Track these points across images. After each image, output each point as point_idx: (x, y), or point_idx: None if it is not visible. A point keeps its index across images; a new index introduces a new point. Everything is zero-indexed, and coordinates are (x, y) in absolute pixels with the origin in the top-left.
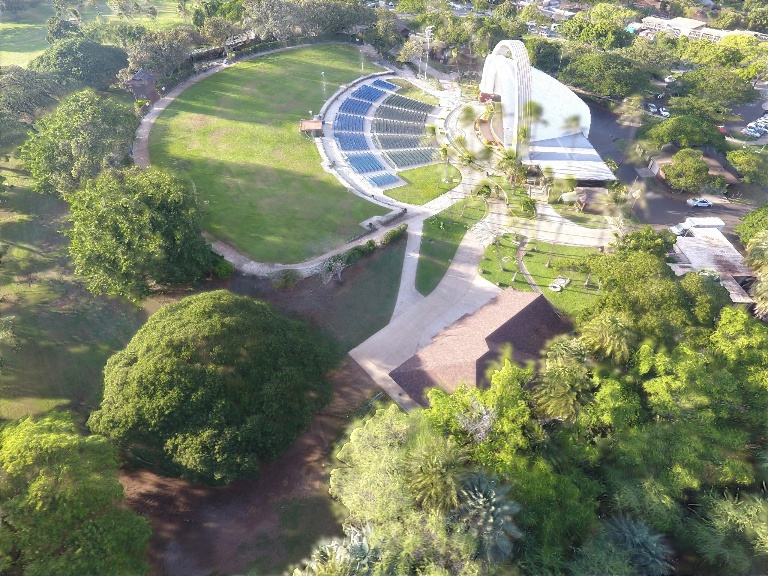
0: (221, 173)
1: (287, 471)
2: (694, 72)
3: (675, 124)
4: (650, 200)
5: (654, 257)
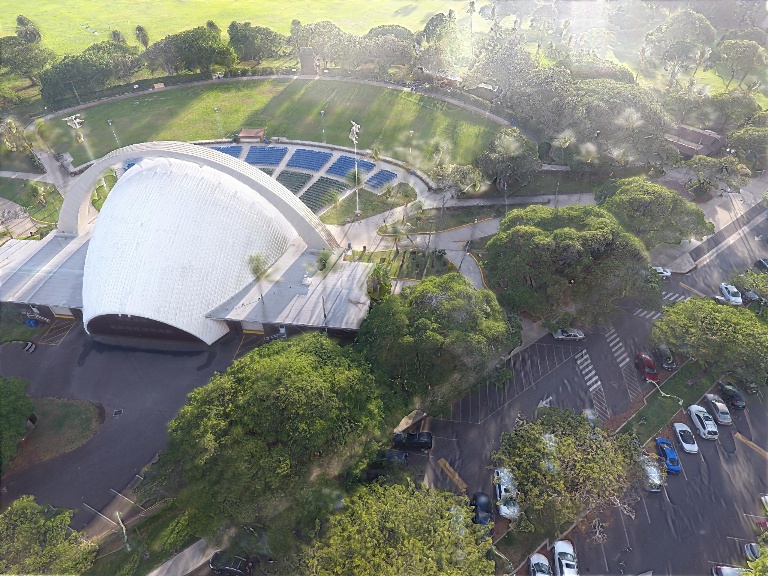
0: (177, 105)
1: None
2: None
3: None
4: None
5: None
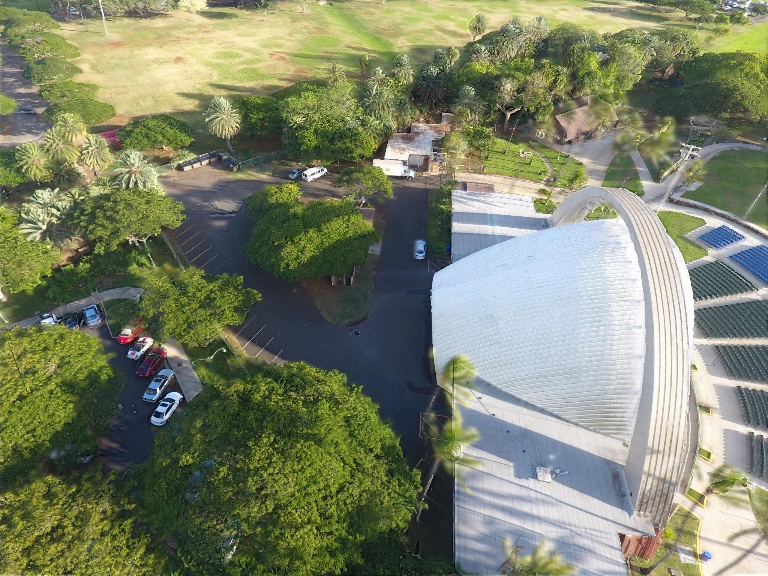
0: None
1: None
2: (3, 433)
3: (345, 207)
4: (401, 210)
5: (511, 76)
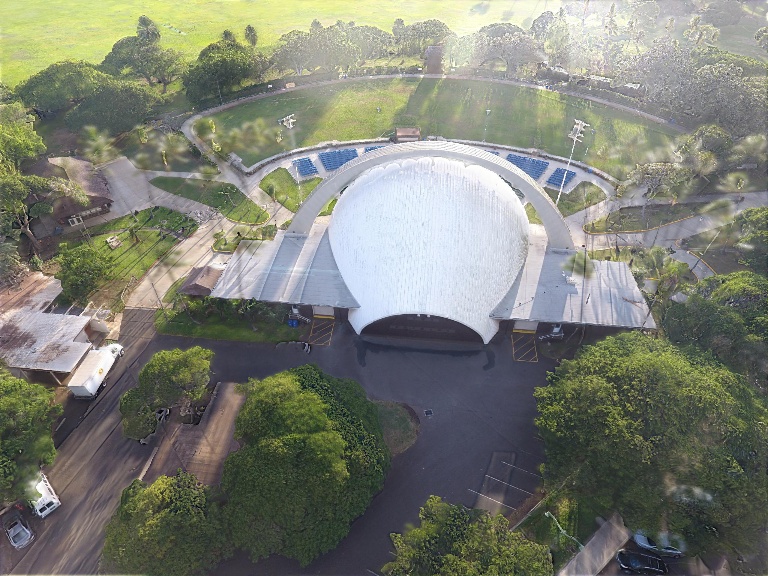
0: (317, 104)
1: (76, 145)
2: None
3: None
4: None
5: (4, 187)
